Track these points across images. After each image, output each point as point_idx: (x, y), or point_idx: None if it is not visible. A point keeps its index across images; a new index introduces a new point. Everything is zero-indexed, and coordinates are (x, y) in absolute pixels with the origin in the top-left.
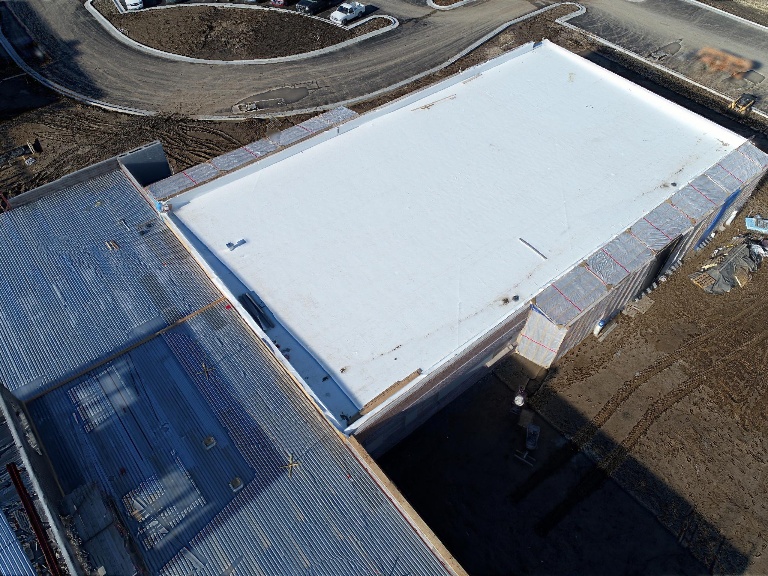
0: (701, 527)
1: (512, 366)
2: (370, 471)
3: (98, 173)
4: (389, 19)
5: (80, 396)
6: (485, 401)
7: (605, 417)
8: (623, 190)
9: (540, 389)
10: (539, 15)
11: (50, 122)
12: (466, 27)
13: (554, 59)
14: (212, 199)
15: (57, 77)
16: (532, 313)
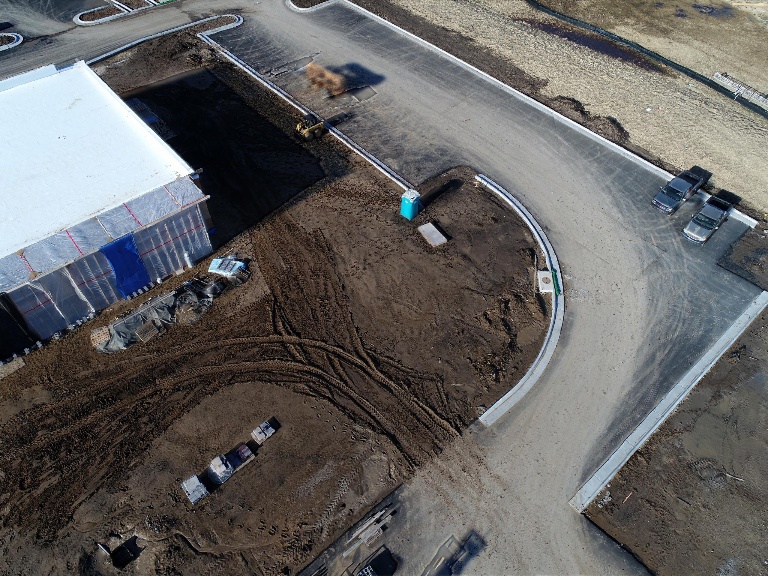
0: None
1: None
2: None
3: None
4: (14, 37)
5: None
6: None
7: None
8: (5, 237)
9: None
10: (185, 29)
11: None
12: (93, 44)
13: (74, 83)
14: None
15: None
16: None
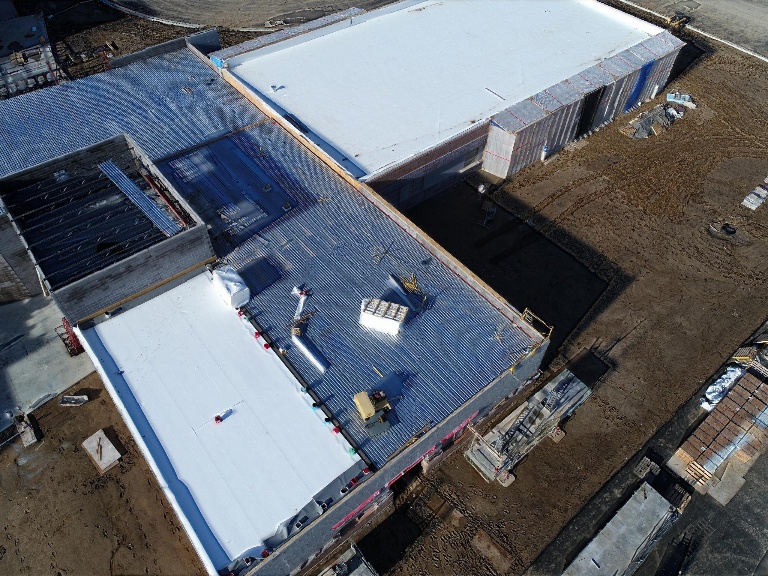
0: (605, 262)
1: (479, 177)
2: (375, 201)
3: (171, 49)
4: None
5: (177, 165)
6: (458, 196)
7: (544, 205)
8: (567, 62)
9: (498, 190)
10: None
11: (121, 31)
12: None
13: None
14: (258, 63)
15: (122, 2)
16: (491, 128)
